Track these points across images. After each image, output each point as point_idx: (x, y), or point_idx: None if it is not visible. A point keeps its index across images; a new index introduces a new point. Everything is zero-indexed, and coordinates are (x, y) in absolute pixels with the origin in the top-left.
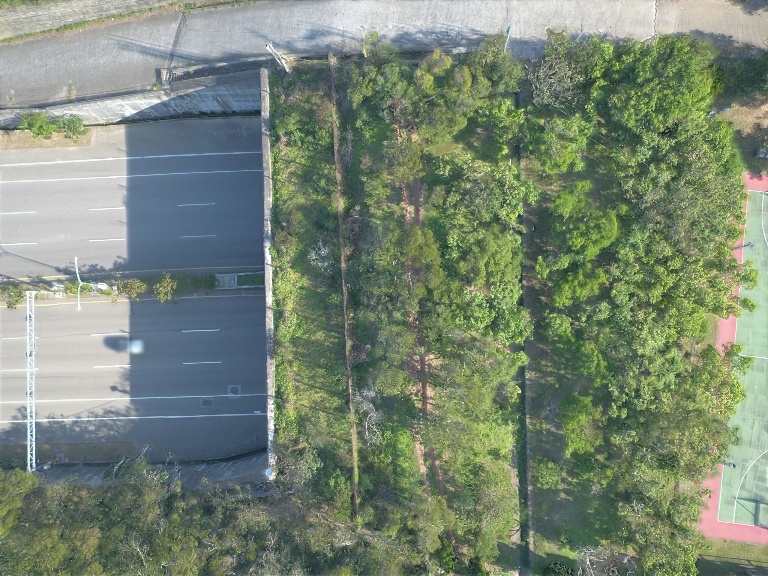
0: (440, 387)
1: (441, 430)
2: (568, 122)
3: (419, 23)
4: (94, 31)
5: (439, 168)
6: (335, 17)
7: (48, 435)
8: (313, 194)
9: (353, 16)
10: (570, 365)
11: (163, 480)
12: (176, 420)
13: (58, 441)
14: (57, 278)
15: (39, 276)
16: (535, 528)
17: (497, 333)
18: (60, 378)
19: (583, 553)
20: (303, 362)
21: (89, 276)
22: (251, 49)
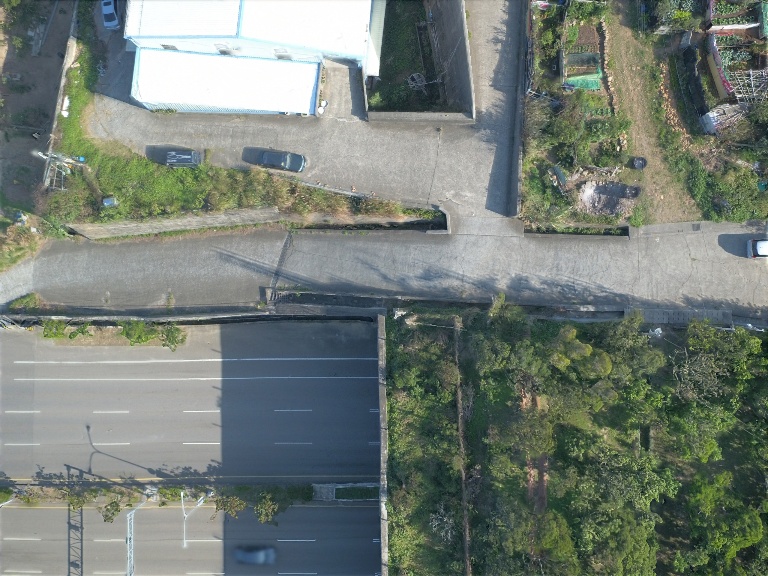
0: None
1: None
2: (712, 414)
3: (544, 274)
4: (195, 240)
5: (573, 452)
6: (455, 260)
7: None
8: (431, 448)
9: (474, 261)
10: None
11: None
12: None
13: None
14: (150, 480)
15: (132, 477)
16: None
17: None
18: None
19: None
20: None
21: (183, 480)
22: (363, 281)
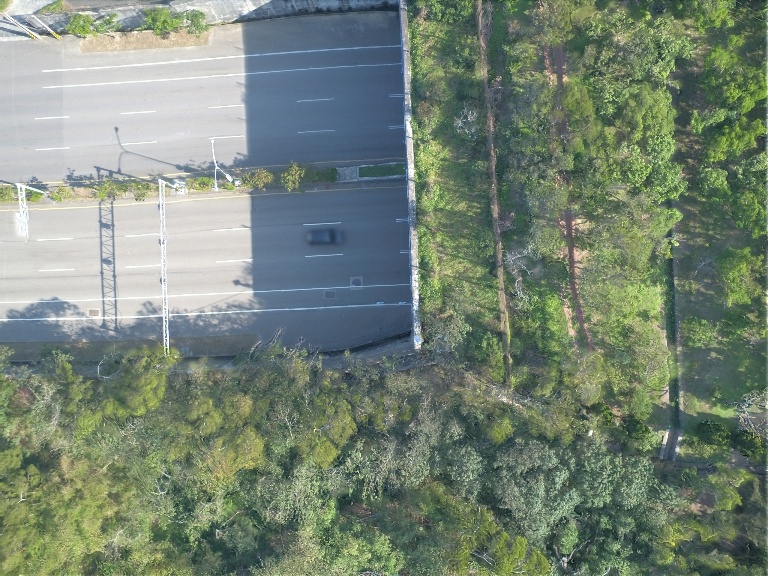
0: (587, 251)
1: (600, 283)
2: None
3: None
4: None
5: (591, 27)
6: None
7: (172, 330)
8: (453, 67)
9: None
10: (719, 225)
11: (303, 357)
12: (299, 312)
13: (182, 335)
14: (178, 176)
15: (160, 174)
16: (685, 388)
17: (651, 190)
18: (183, 274)
19: (747, 398)
20: (446, 233)
21: (210, 173)
22: None
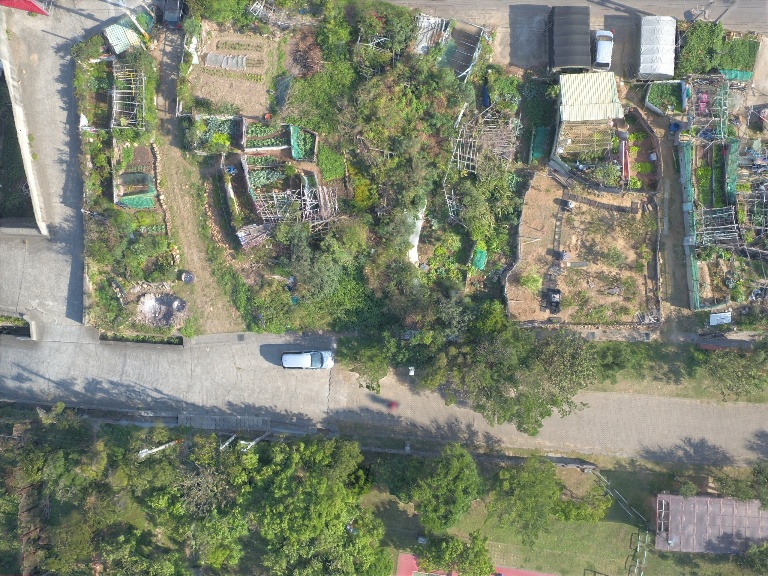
0: None
1: None
2: (218, 524)
3: (115, 379)
4: None
5: (103, 556)
6: (42, 365)
7: None
8: None
9: (57, 366)
10: None
11: None
12: None
13: None
14: None
15: None
16: None
17: None
18: None
19: None
20: None
21: None
22: None
